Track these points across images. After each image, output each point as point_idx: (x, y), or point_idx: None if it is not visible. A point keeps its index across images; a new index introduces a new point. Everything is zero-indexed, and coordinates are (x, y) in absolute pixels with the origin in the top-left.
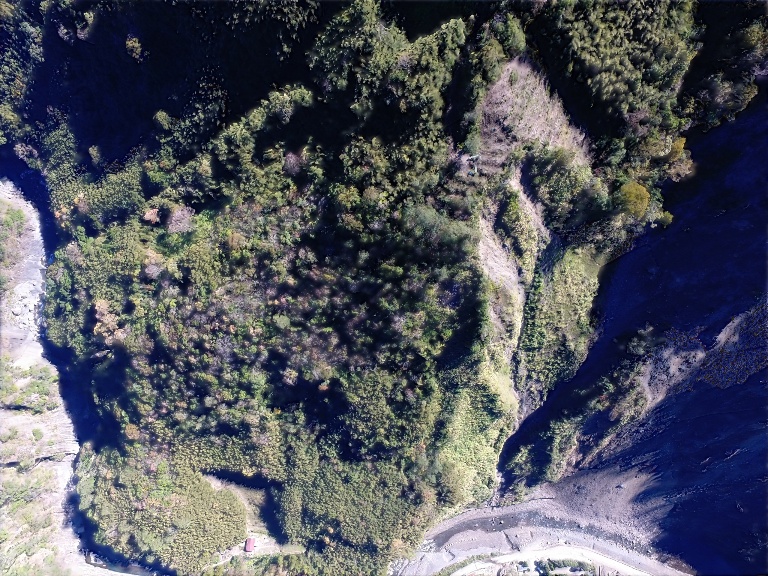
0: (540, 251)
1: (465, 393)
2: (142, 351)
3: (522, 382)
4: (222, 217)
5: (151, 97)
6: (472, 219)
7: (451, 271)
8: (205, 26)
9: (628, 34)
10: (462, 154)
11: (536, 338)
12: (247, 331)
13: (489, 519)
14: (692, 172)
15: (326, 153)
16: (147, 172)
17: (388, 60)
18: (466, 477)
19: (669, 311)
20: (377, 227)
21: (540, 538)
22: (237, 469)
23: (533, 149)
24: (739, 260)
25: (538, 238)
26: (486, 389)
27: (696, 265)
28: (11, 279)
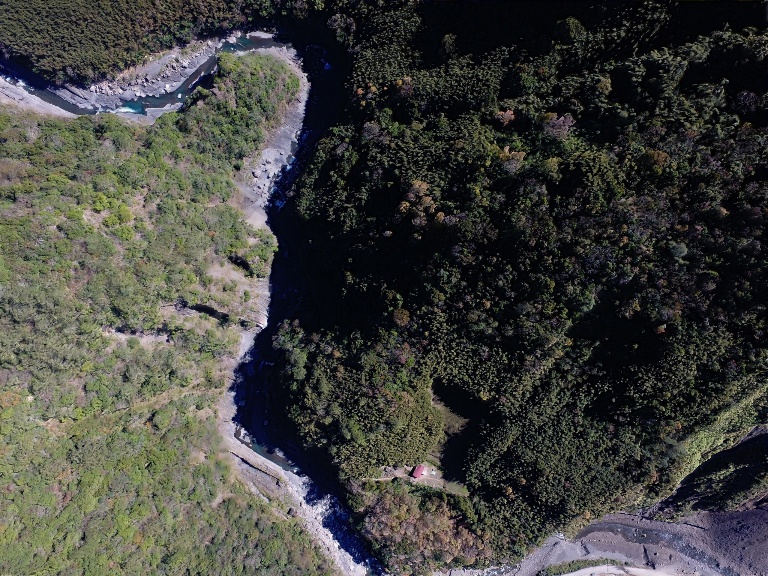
0: None
1: (767, 385)
2: (479, 238)
3: None
4: None
5: (559, 2)
6: None
7: None
8: None
9: None
10: None
11: None
12: (635, 248)
13: (633, 528)
14: None
15: None
16: (521, 73)
17: None
18: None
19: None
20: None
21: (677, 564)
22: (474, 389)
23: None
24: None
25: None
26: None
27: None
28: (265, 141)
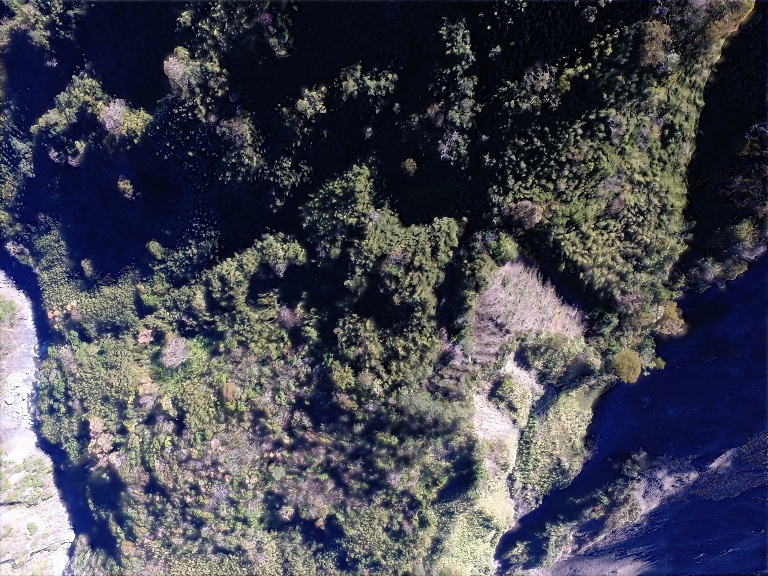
0: (534, 401)
1: (461, 517)
2: (137, 482)
3: (518, 492)
4: (216, 360)
5: (144, 224)
6: (466, 400)
7: (446, 437)
8: (197, 177)
9: (619, 236)
10: (456, 344)
11: (531, 463)
12: (243, 479)
13: None
14: (684, 319)
15: (320, 314)
16: (140, 295)
17: (381, 246)
18: (463, 574)
19: (662, 438)
20: (372, 409)
21: None
22: None
23: (526, 341)
24: (731, 402)
25: (532, 394)
26: (482, 513)
27: (689, 400)
28: (4, 369)
